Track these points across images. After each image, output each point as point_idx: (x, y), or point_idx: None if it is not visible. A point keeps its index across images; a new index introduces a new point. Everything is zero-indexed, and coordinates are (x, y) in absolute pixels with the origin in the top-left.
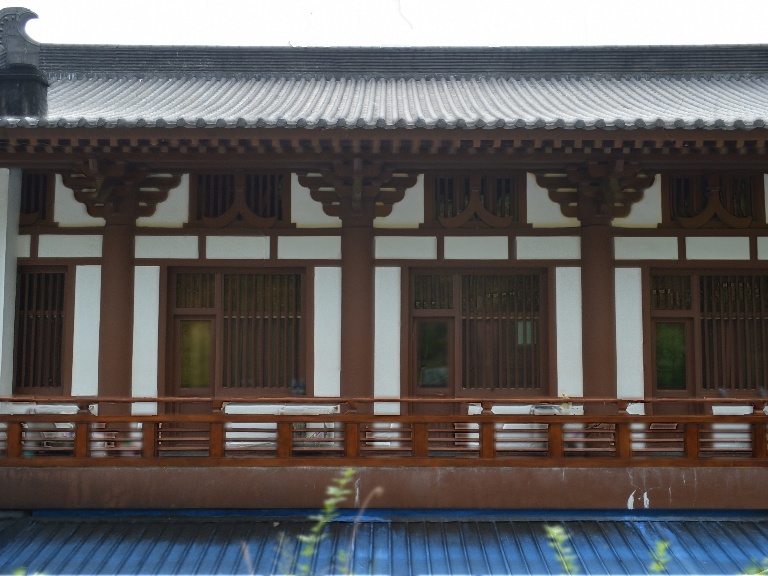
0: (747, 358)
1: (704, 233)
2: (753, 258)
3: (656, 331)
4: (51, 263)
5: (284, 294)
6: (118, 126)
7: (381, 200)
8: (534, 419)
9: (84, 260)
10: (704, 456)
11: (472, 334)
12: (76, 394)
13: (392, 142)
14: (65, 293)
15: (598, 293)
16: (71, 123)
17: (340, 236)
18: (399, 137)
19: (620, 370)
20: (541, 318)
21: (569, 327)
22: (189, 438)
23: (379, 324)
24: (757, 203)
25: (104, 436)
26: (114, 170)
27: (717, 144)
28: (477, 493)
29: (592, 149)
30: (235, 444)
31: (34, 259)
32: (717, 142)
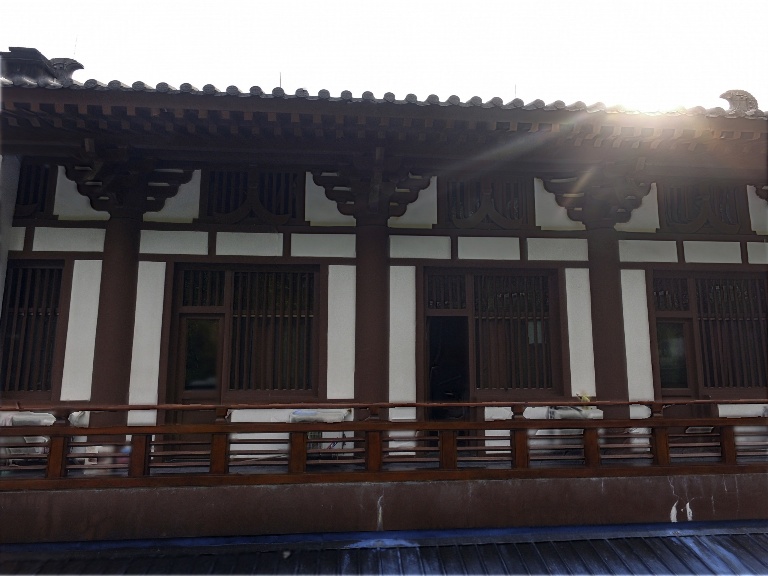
0: (742, 357)
1: (700, 238)
2: (744, 262)
3: (657, 331)
4: (46, 257)
5: (296, 293)
6: (111, 89)
7: (395, 200)
8: (569, 424)
9: (83, 254)
10: (740, 461)
11: (485, 334)
12: (66, 399)
13: (423, 121)
14: (61, 289)
15: (607, 293)
16: (55, 84)
17: (355, 234)
18: (431, 116)
19: (630, 369)
20: (551, 318)
21: (580, 327)
22: (187, 452)
23: (394, 323)
24: (742, 212)
25: (85, 451)
26: (115, 155)
27: (754, 136)
28: (512, 509)
29: (621, 142)
30: (240, 458)
31: (28, 253)
32: (754, 134)
